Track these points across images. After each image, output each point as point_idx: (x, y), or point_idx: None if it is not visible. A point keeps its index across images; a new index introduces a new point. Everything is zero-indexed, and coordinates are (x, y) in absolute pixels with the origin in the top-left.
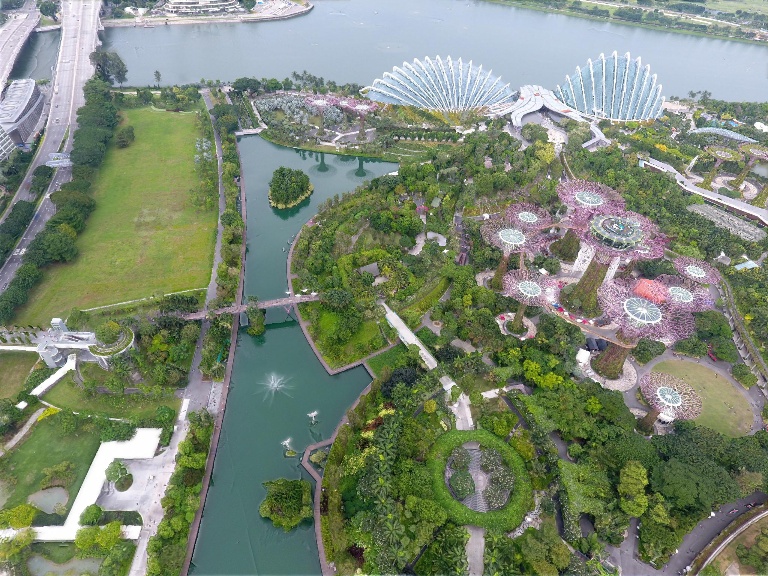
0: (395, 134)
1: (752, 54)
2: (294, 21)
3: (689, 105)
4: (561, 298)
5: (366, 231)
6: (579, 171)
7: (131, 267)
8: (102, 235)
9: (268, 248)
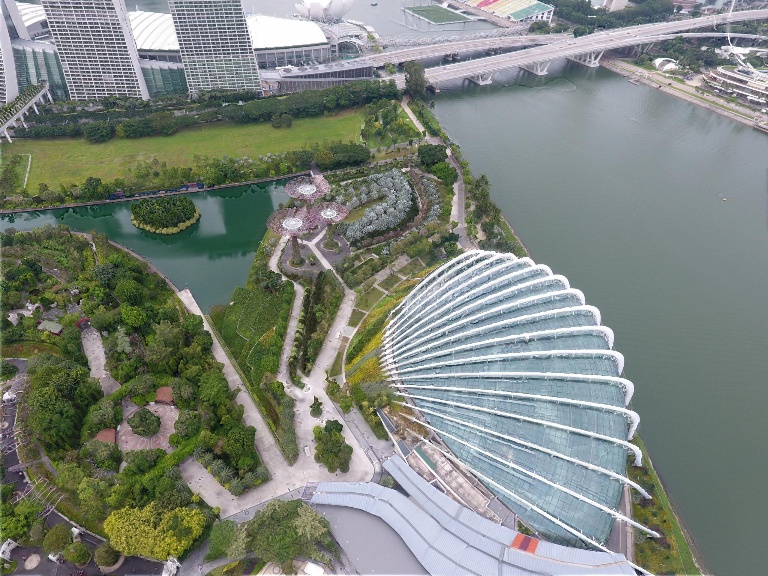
0: None
1: None
2: None
3: None
4: None
5: None
6: None
7: (71, 163)
8: (124, 146)
9: None
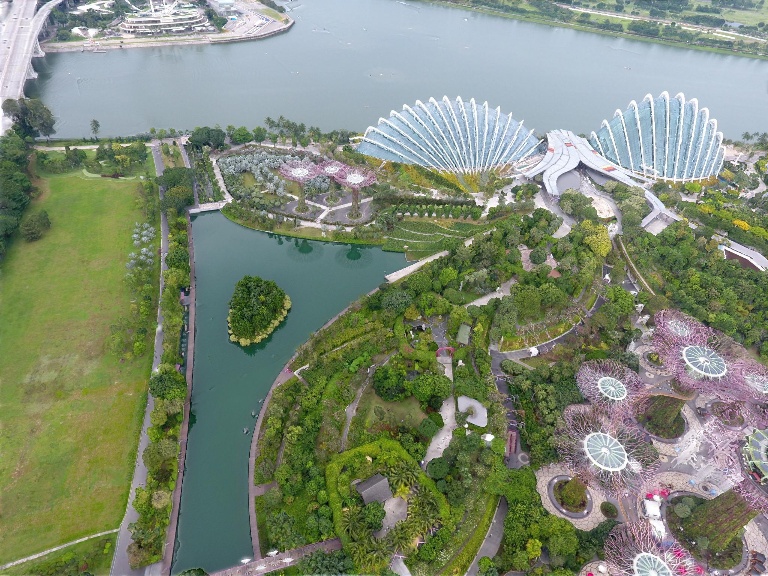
0: (398, 211)
1: None
2: (272, 41)
3: (745, 150)
4: (673, 526)
5: (367, 394)
6: (647, 269)
7: (1, 487)
8: None
9: (224, 417)
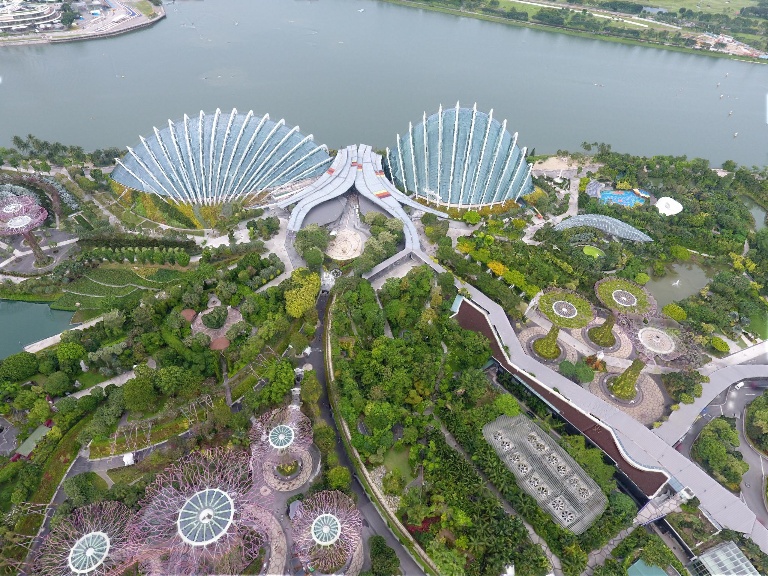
0: (86, 258)
1: (693, 65)
2: (128, 38)
3: (581, 163)
4: None
5: None
6: (339, 334)
7: None
8: None
9: None
